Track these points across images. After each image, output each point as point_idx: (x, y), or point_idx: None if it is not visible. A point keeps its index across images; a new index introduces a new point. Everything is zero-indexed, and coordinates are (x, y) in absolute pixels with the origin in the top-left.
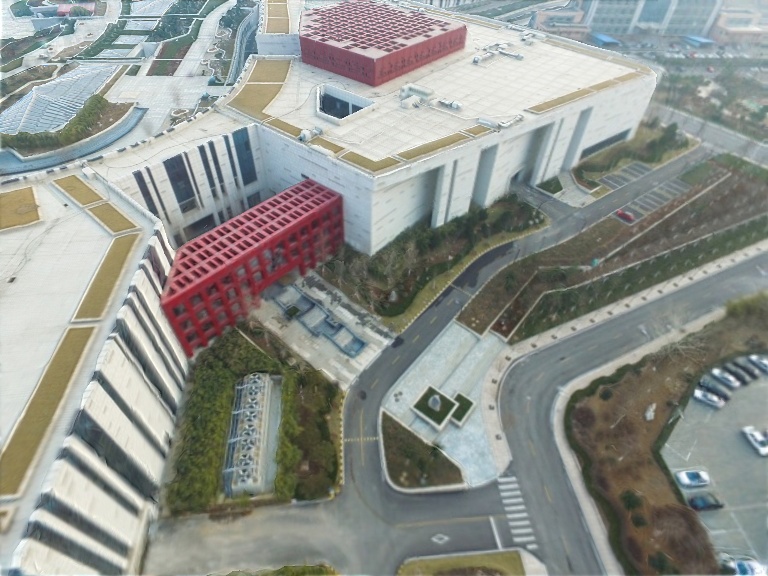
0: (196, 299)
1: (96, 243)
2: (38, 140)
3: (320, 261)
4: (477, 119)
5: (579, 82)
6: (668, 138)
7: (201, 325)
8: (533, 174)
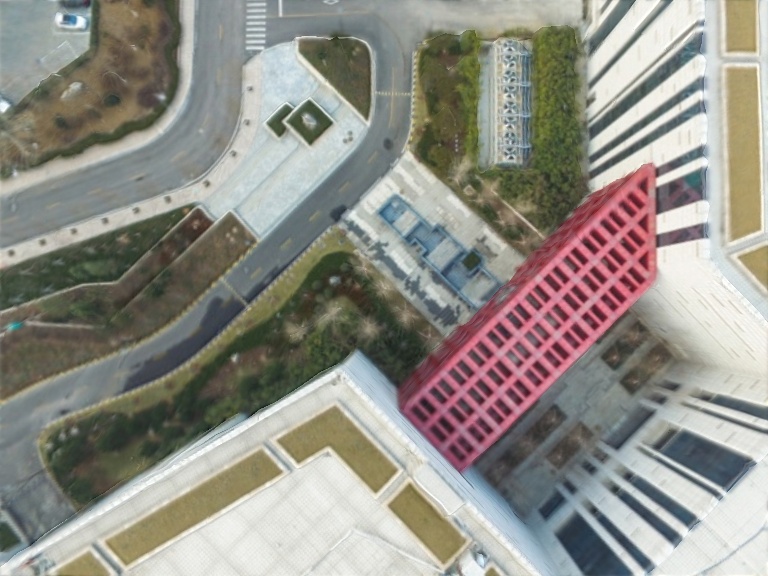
0: None
1: None
2: None
3: None
4: None
5: None
6: None
7: None
8: None
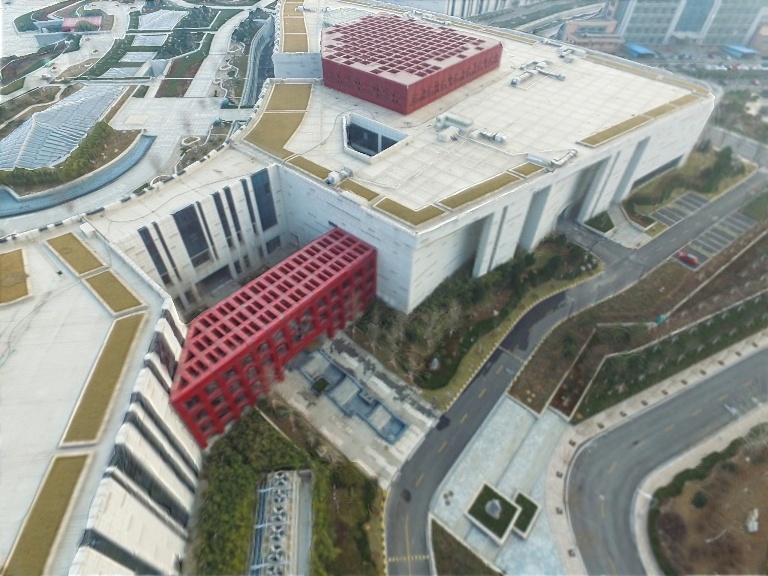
0: (211, 387)
1: (93, 327)
2: (36, 177)
3: (350, 320)
4: (525, 155)
5: (631, 107)
6: (723, 164)
7: (217, 413)
8: (581, 210)
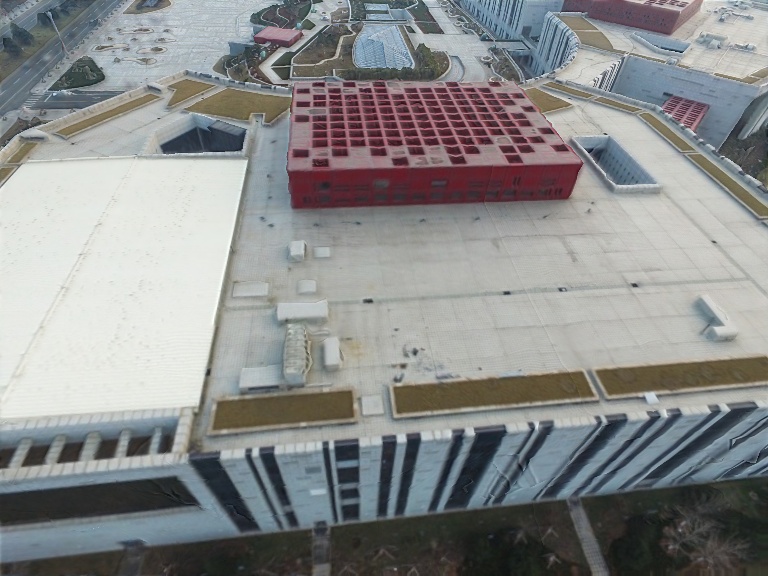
0: None
1: (627, 118)
2: (419, 73)
3: None
4: None
5: None
6: None
7: None
8: None
